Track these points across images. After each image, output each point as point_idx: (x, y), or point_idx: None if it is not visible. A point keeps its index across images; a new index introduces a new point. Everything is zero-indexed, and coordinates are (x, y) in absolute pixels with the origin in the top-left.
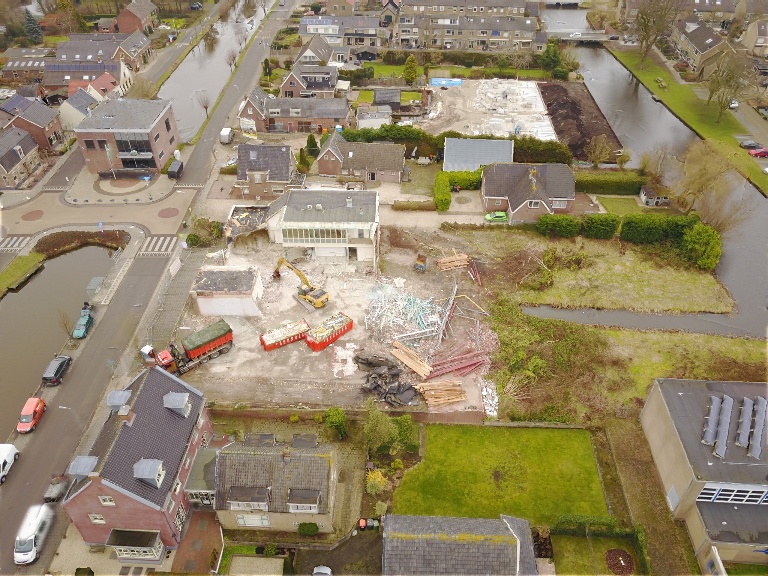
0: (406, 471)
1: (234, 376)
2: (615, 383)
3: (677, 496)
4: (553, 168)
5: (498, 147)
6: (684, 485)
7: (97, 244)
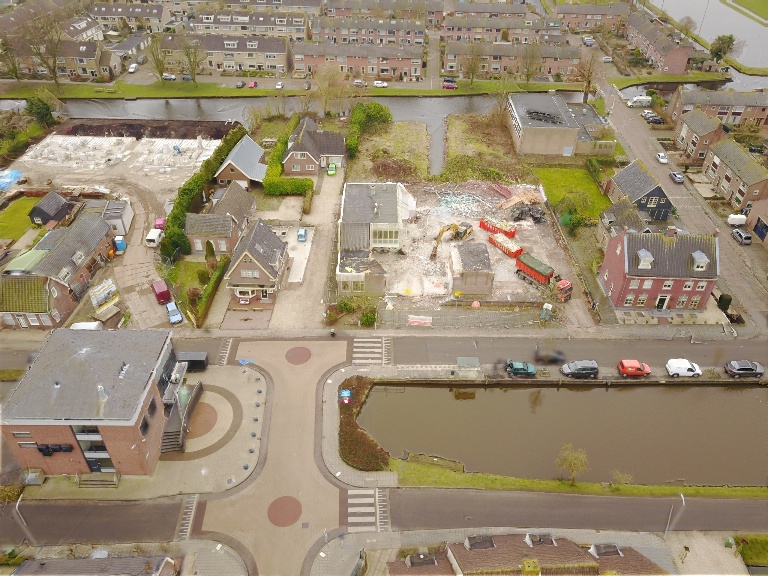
0: None
1: None
2: (495, 157)
3: (571, 147)
4: (308, 123)
5: (248, 145)
6: (573, 138)
7: None
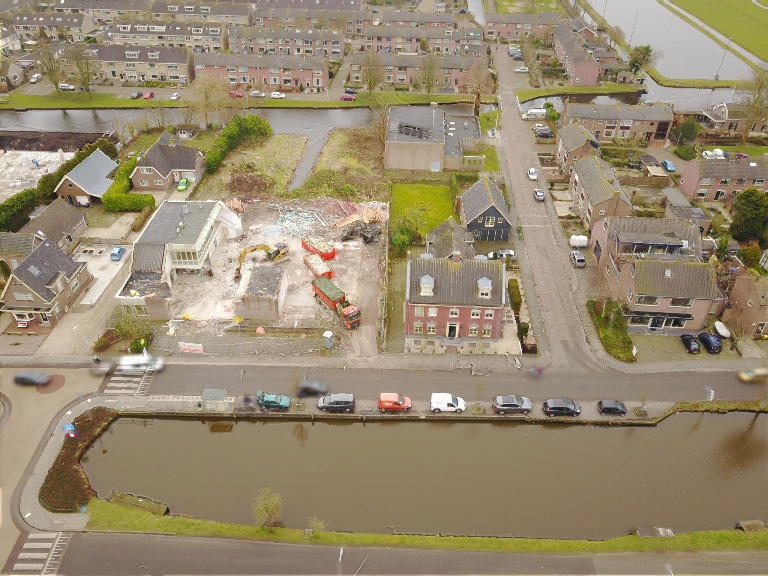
0: (424, 235)
1: (356, 292)
2: (361, 172)
3: (438, 162)
4: (164, 137)
5: (97, 159)
6: (439, 153)
7: (85, 449)
